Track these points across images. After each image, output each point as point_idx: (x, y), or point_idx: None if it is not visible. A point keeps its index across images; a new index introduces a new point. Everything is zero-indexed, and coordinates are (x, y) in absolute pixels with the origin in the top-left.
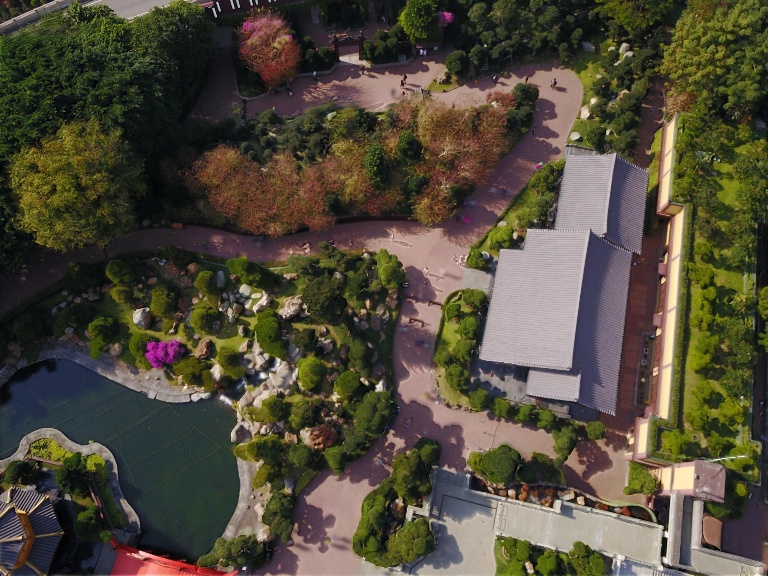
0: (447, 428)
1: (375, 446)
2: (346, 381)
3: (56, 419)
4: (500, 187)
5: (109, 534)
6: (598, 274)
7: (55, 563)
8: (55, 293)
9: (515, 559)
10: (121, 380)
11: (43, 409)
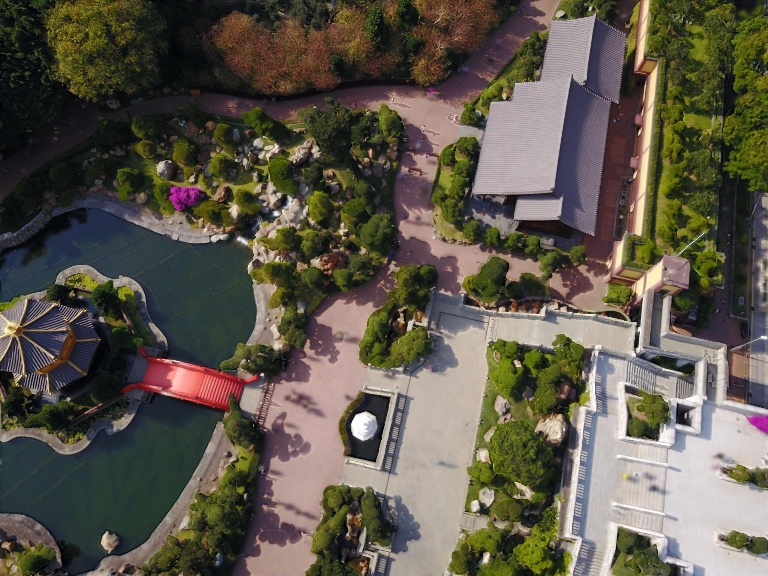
0: (443, 259)
1: (378, 275)
2: (352, 206)
3: (89, 258)
4: (491, 58)
5: (141, 340)
6: (579, 116)
7: (92, 372)
8: (85, 150)
9: (505, 356)
10: (147, 225)
11: (76, 250)
